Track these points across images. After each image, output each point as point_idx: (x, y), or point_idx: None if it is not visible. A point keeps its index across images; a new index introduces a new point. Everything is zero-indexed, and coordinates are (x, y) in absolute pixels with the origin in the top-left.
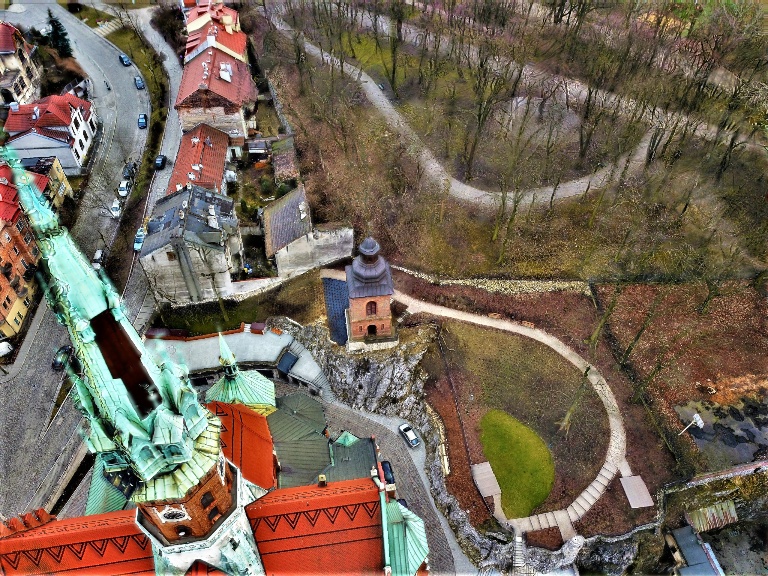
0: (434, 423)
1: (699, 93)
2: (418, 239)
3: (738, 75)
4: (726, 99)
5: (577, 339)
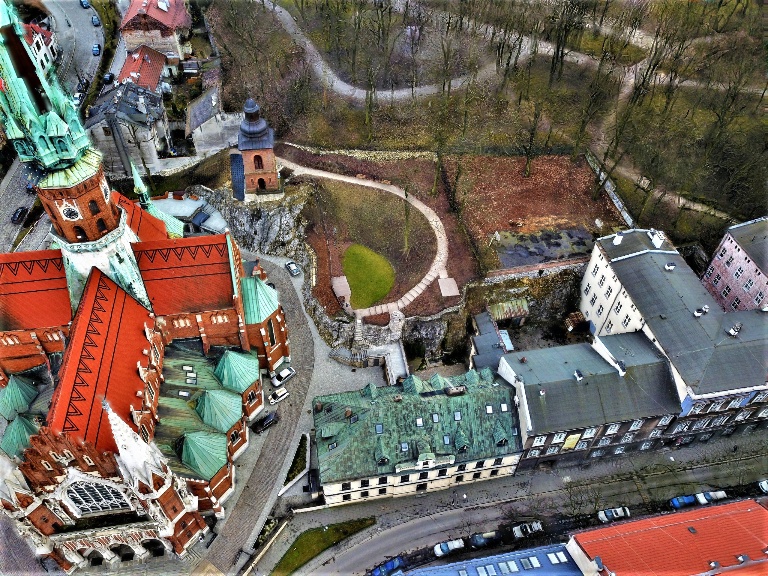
0: (310, 256)
1: None
2: (307, 123)
3: (593, 11)
4: None
5: (422, 191)
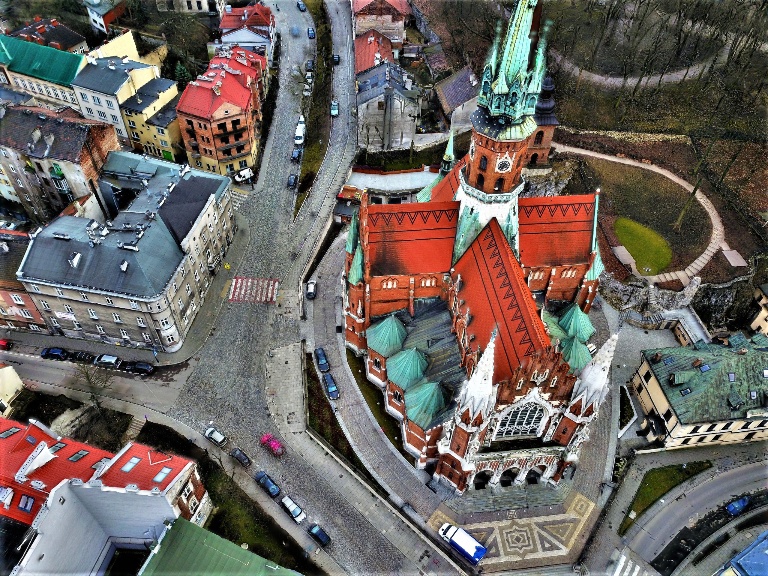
0: None
1: (764, 19)
2: (559, 105)
3: None
4: None
5: (684, 171)
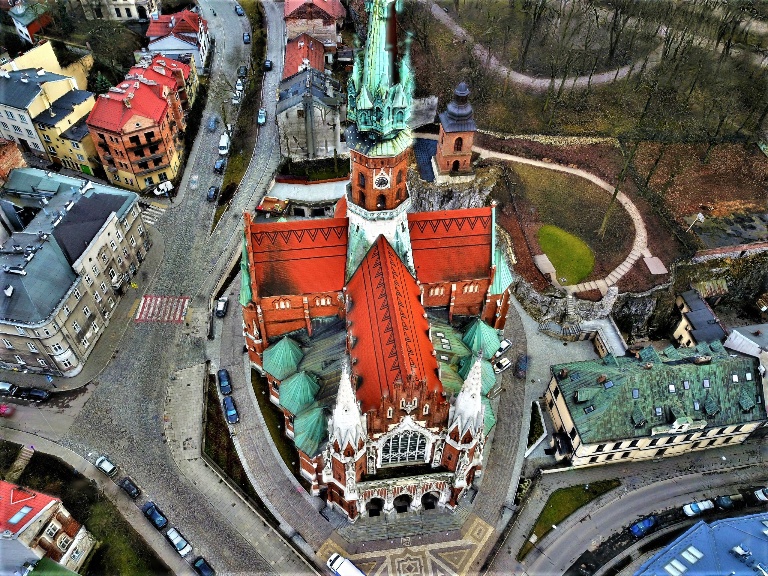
0: (502, 236)
1: None
2: (486, 109)
3: None
4: (725, 9)
5: (610, 175)
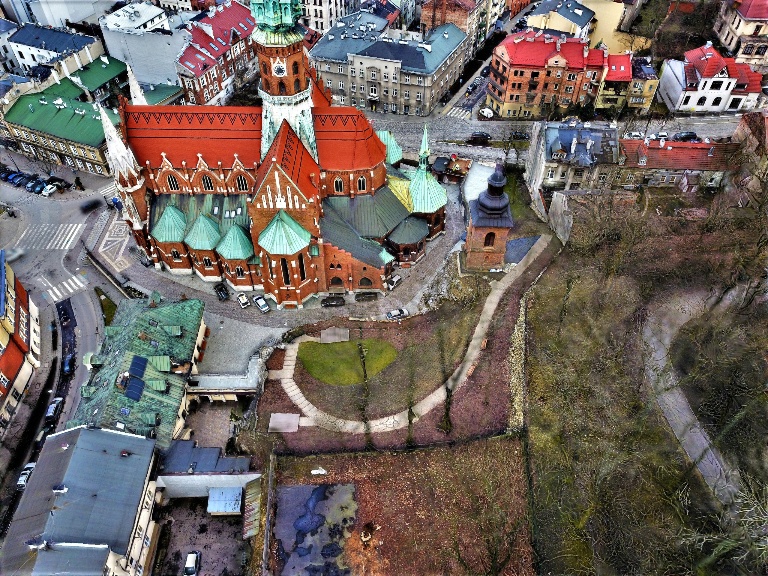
0: None
1: None
2: None
3: None
4: None
5: None
